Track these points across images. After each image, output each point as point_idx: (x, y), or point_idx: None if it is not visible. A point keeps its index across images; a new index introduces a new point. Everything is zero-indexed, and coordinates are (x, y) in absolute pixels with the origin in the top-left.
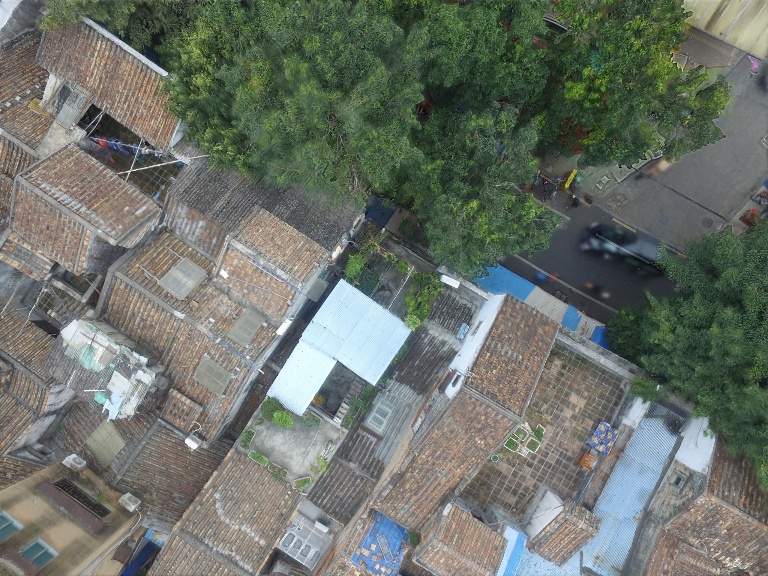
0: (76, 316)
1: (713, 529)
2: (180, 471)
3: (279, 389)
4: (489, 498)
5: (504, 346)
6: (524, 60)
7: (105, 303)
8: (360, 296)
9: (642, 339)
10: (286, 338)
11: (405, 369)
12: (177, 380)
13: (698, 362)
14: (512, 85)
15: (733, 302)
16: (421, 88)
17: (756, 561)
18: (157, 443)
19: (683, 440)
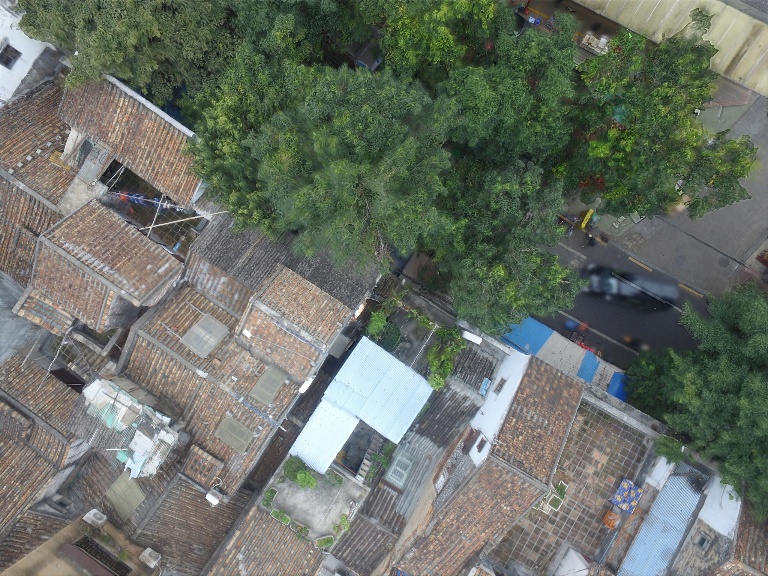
0: (99, 376)
1: None
2: (199, 523)
3: (301, 447)
4: (511, 555)
5: (530, 411)
6: (549, 119)
7: (127, 359)
8: (383, 353)
9: (663, 391)
10: (306, 390)
11: (426, 422)
12: (198, 436)
13: (724, 425)
14: (536, 142)
15: (759, 366)
16: (448, 156)
17: None
18: (177, 496)
19: (706, 498)
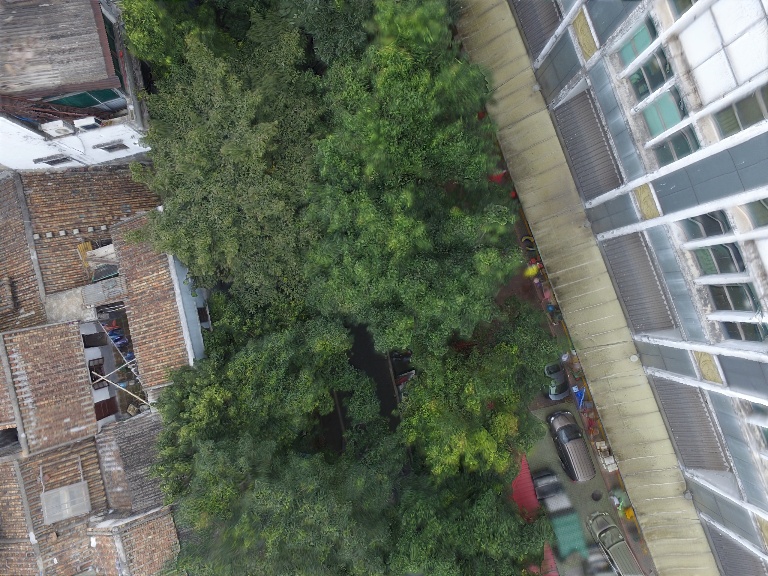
0: None
1: None
2: None
3: None
4: None
5: None
6: None
7: None
8: None
9: None
10: None
11: None
12: None
13: None
14: None
15: None
16: None
17: None
18: None
19: None
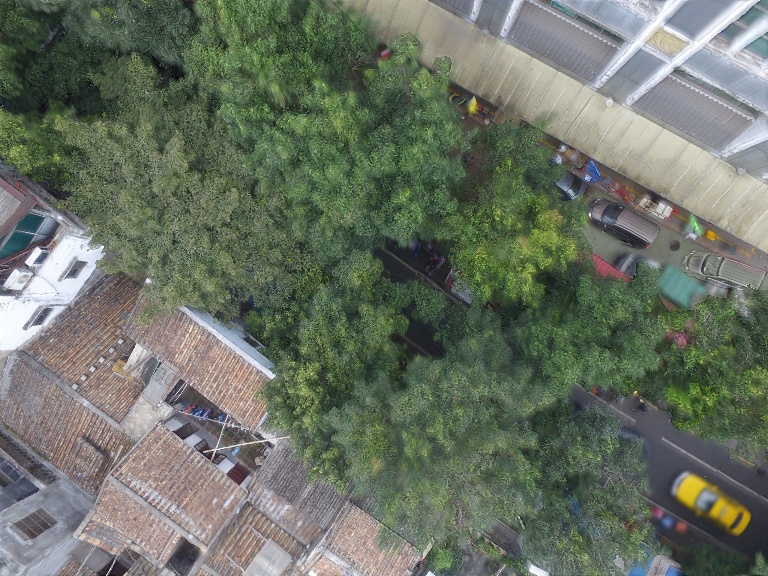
0: None
1: None
2: None
3: None
4: None
5: None
6: (628, 367)
7: None
8: None
9: None
10: None
11: None
12: None
13: None
14: (612, 382)
15: None
16: None
17: None
18: None
19: None
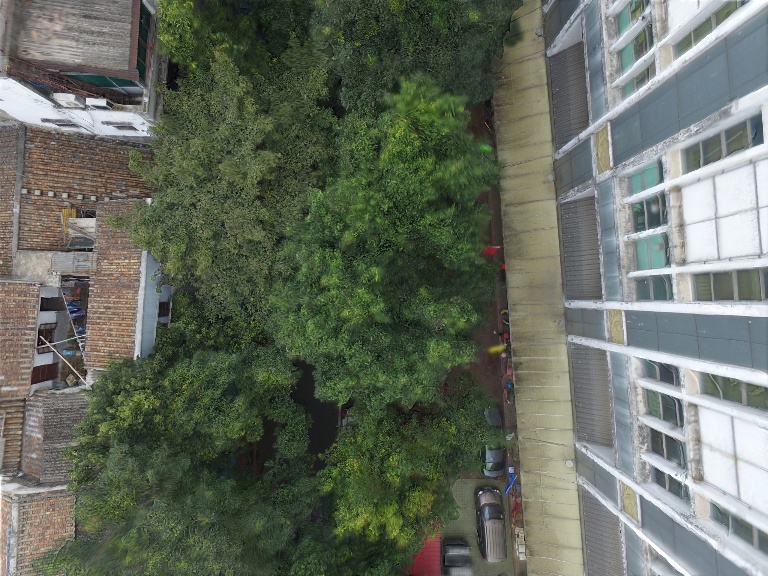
0: None
1: None
2: None
3: None
4: None
5: None
6: None
7: None
8: None
9: None
10: None
11: None
12: None
13: None
14: None
15: None
16: None
17: None
18: None
19: None
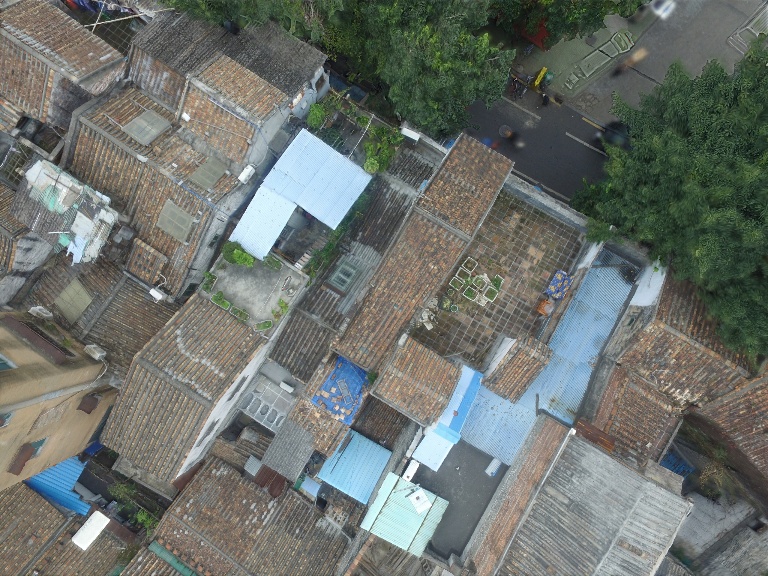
0: (40, 157)
1: (662, 359)
2: (147, 332)
3: (241, 234)
4: (449, 348)
5: (458, 177)
6: None
7: (70, 153)
8: (321, 145)
9: None
10: None
11: (368, 229)
12: (142, 231)
13: None
14: None
15: (682, 136)
16: None
17: (704, 391)
18: (124, 300)
19: (638, 287)
